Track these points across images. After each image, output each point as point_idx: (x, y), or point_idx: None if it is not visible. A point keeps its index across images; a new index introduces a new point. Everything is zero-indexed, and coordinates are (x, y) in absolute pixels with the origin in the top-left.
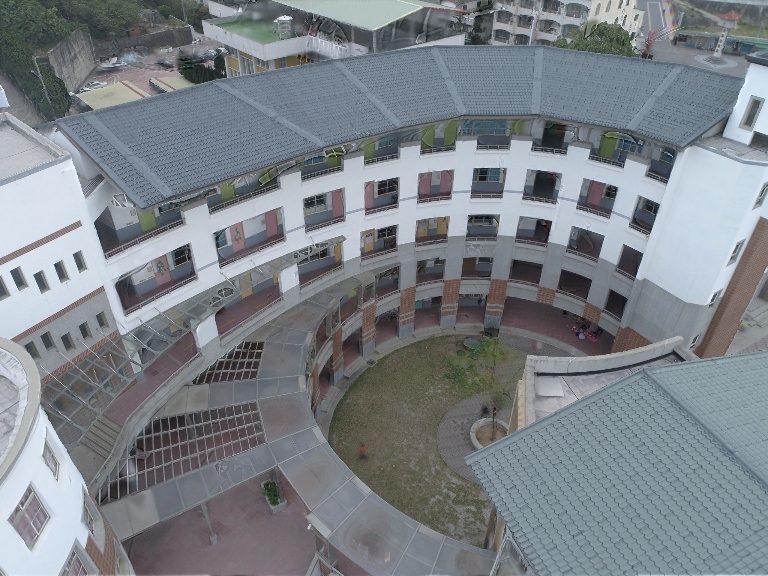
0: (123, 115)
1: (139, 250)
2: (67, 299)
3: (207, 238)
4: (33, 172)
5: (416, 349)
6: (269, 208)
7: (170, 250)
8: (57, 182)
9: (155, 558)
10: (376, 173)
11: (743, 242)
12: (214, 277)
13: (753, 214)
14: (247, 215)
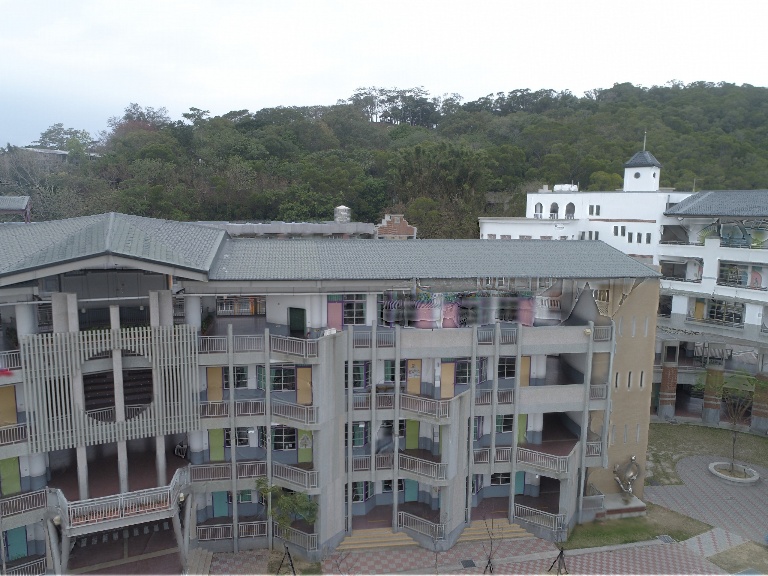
0: (723, 193)
1: (675, 247)
2: (636, 251)
3: (713, 260)
4: (646, 192)
5: None
6: (760, 261)
7: (691, 256)
8: None
9: None
10: None
11: None
12: (711, 288)
13: None
14: (743, 259)
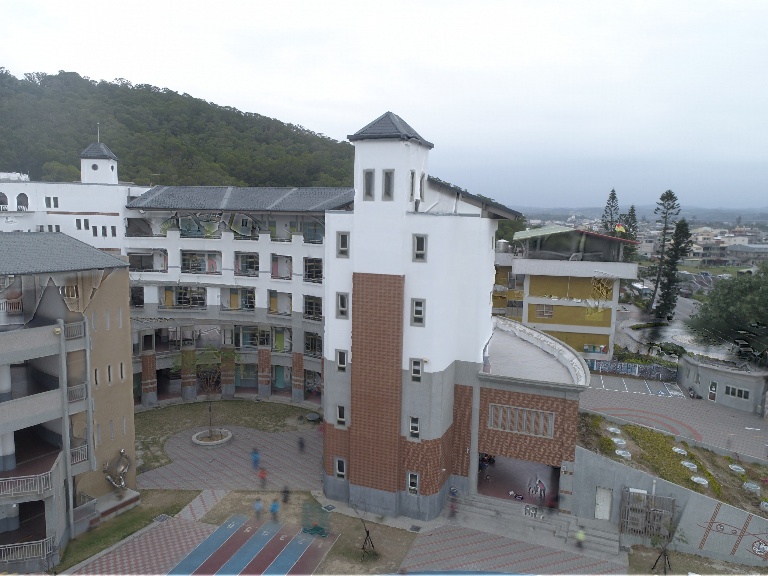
0: None
1: (140, 239)
2: (102, 245)
3: (176, 250)
4: (106, 185)
5: (288, 407)
6: (213, 249)
7: (156, 248)
8: (115, 193)
9: None
10: (277, 249)
11: (348, 296)
12: (176, 276)
13: (343, 264)
14: (200, 248)
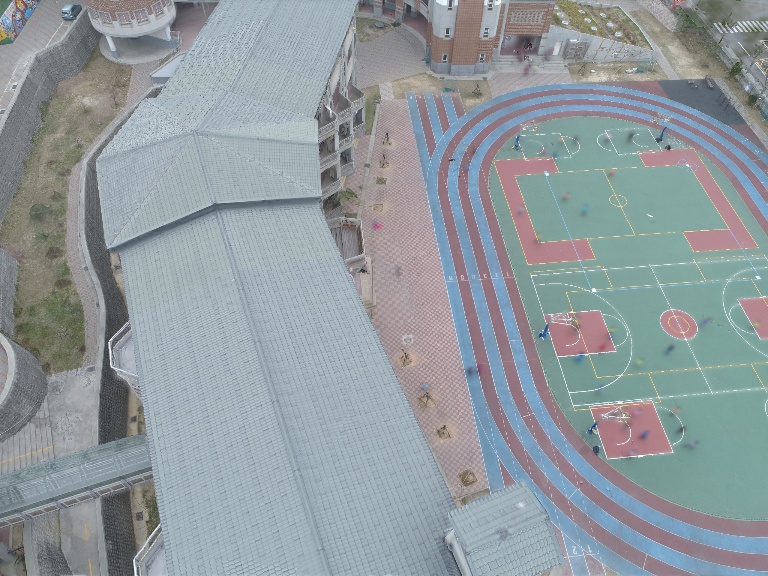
0: None
1: None
2: None
3: None
4: None
5: None
6: None
7: None
8: None
9: (189, 25)
10: None
11: None
12: None
13: None
14: None
